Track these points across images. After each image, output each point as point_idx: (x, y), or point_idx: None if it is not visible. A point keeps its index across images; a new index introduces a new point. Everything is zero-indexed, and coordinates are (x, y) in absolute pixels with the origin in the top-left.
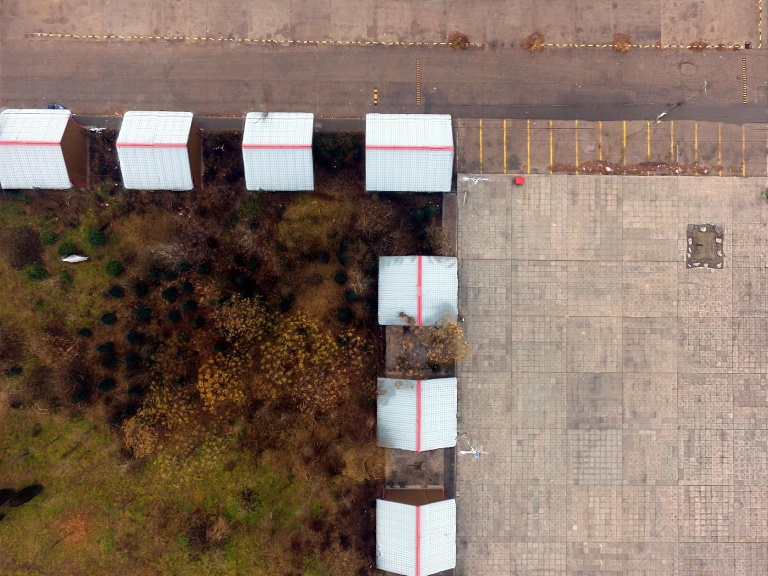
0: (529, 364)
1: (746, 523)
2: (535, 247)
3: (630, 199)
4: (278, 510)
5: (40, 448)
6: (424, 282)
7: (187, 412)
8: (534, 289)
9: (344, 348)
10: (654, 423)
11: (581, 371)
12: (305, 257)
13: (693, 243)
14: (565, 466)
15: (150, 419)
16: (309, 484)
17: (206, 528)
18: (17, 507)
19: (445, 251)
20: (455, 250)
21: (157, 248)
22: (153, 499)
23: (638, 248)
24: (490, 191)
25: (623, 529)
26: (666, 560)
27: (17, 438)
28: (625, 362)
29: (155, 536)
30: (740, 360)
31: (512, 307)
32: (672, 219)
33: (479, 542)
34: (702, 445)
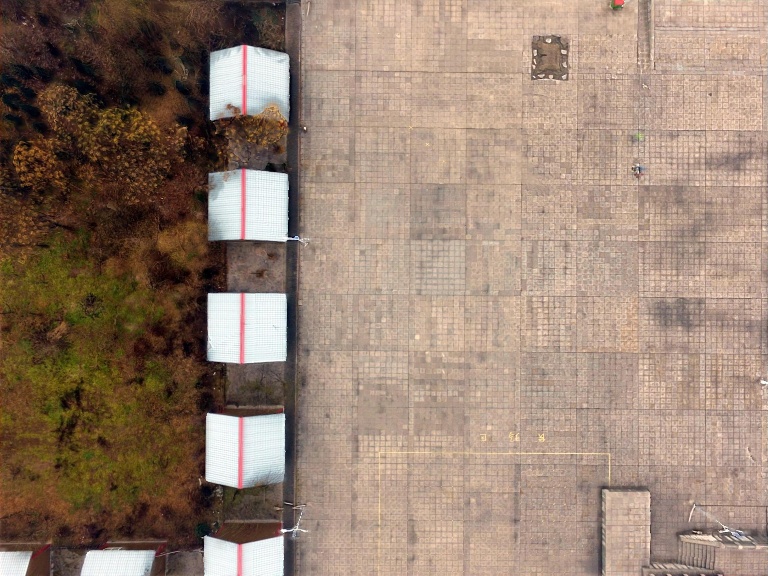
0: (372, 175)
1: (588, 333)
2: (379, 58)
3: (475, 10)
4: (122, 317)
5: None
6: (249, 72)
7: (6, 189)
8: (378, 100)
9: (170, 138)
10: (497, 234)
11: (425, 182)
12: (147, 66)
13: (538, 54)
14: (408, 276)
15: None
16: (153, 292)
17: (48, 331)
18: None
19: (272, 43)
20: (298, 60)
21: (1, 57)
22: None
23: (483, 59)
24: (334, 2)
25: (465, 339)
26: (508, 369)
27: None
28: (469, 173)
29: None
30: (584, 172)
31: (356, 118)
32: (517, 30)
33: (321, 350)
34: (545, 256)
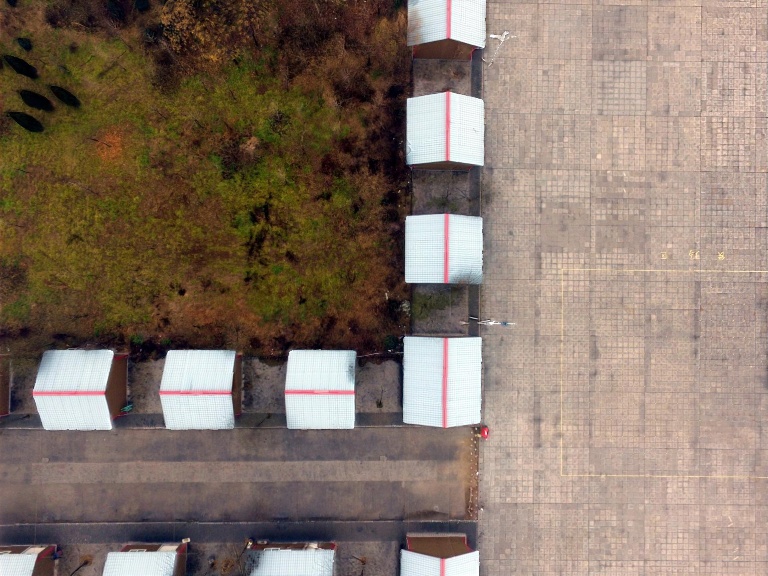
0: None
1: (767, 154)
2: None
3: None
4: (309, 134)
5: (77, 66)
6: None
7: None
8: None
9: None
10: (678, 55)
11: (606, 4)
12: None
13: None
14: (590, 96)
15: (187, 0)
16: (339, 110)
17: (239, 144)
18: (55, 123)
19: None
20: None
21: None
22: (187, 119)
23: None
24: None
25: (646, 158)
26: (688, 189)
27: (55, 55)
28: None
29: (189, 154)
30: None
31: None
32: None
33: (505, 168)
34: (725, 77)
